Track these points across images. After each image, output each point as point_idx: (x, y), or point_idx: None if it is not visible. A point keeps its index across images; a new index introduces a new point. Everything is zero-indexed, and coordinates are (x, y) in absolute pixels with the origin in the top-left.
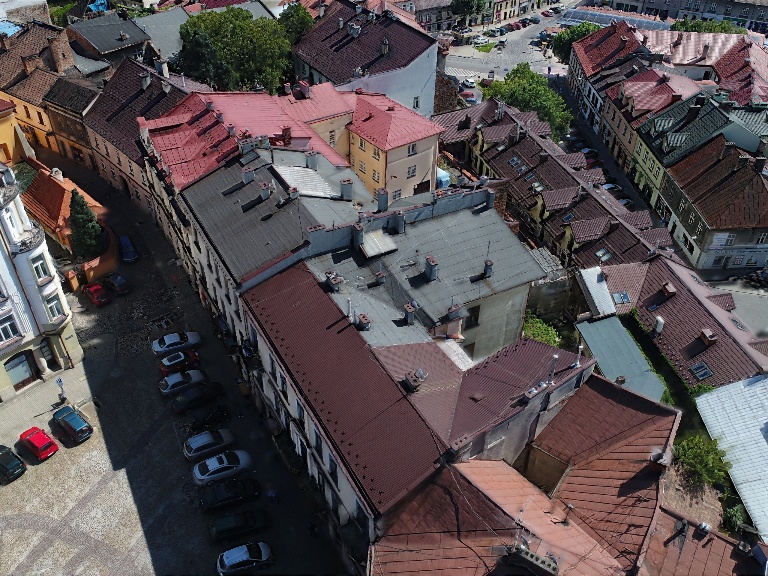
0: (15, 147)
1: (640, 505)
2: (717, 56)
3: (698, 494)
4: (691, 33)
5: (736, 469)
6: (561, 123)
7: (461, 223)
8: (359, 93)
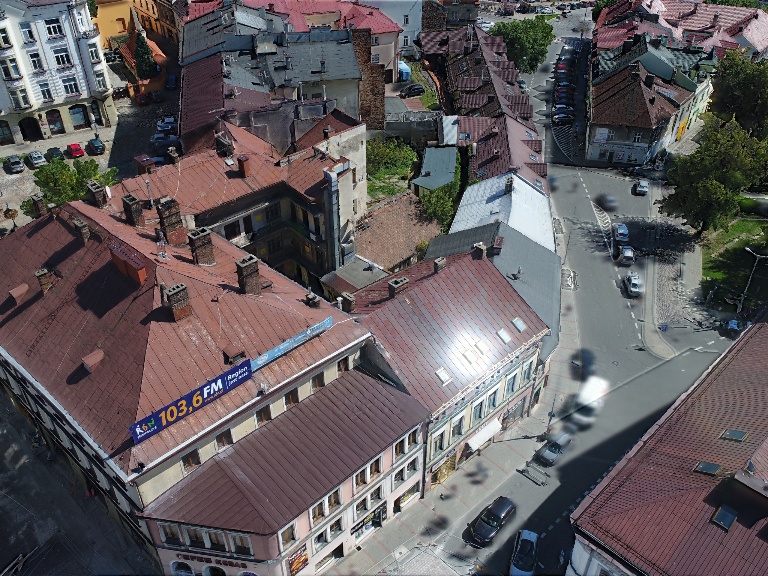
0: (130, 22)
1: None
2: (726, 25)
3: (426, 222)
4: (708, 5)
5: (460, 216)
6: (535, 54)
7: (326, 47)
8: (356, 4)
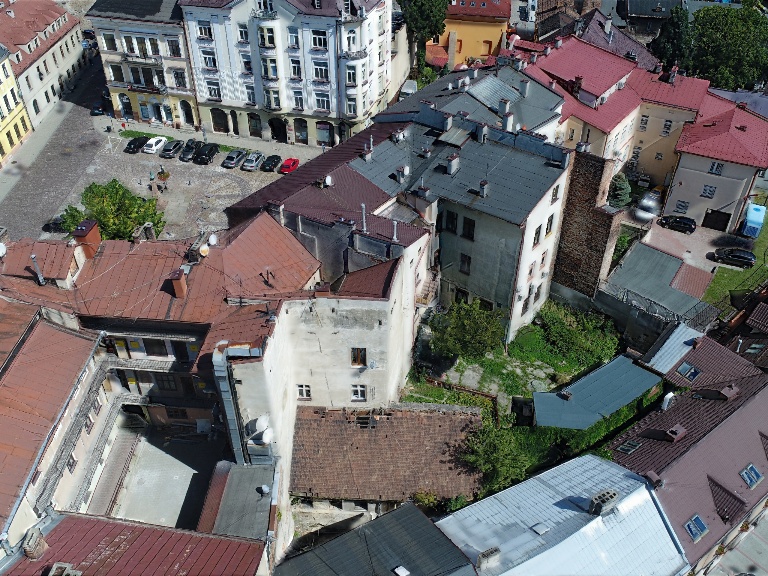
0: (497, 47)
1: (287, 297)
2: None
3: (462, 468)
4: None
5: (512, 492)
6: None
7: (526, 162)
8: (741, 107)
